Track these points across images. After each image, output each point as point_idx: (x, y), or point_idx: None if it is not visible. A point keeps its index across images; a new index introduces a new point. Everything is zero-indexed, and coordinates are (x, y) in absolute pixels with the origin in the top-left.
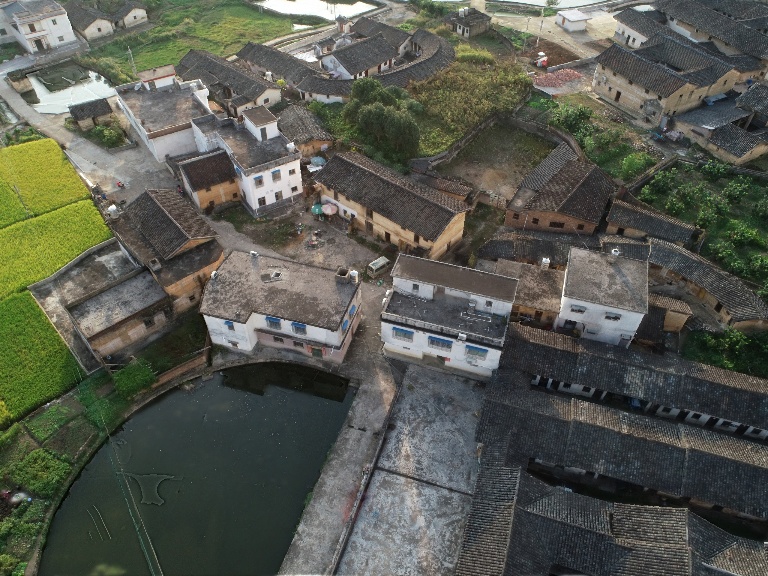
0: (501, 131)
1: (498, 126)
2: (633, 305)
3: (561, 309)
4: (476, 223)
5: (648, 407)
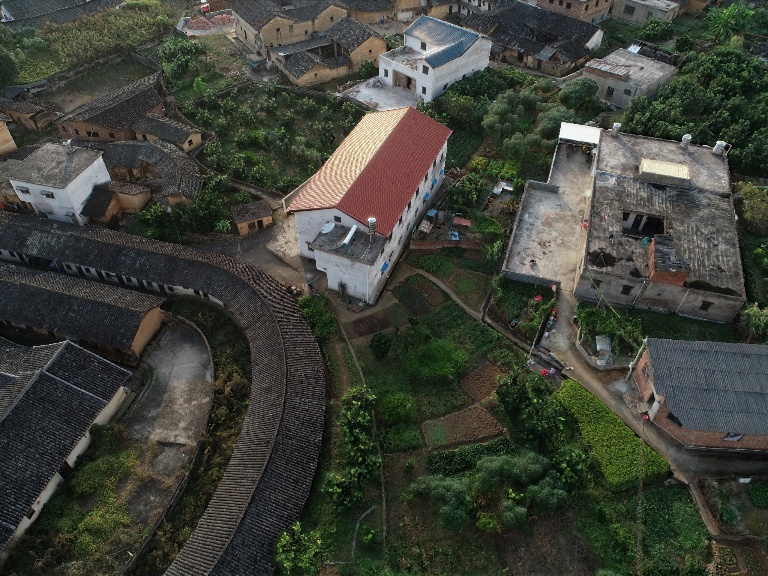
0: (124, 66)
1: (124, 62)
2: (56, 182)
3: (16, 192)
4: (37, 137)
5: (57, 266)
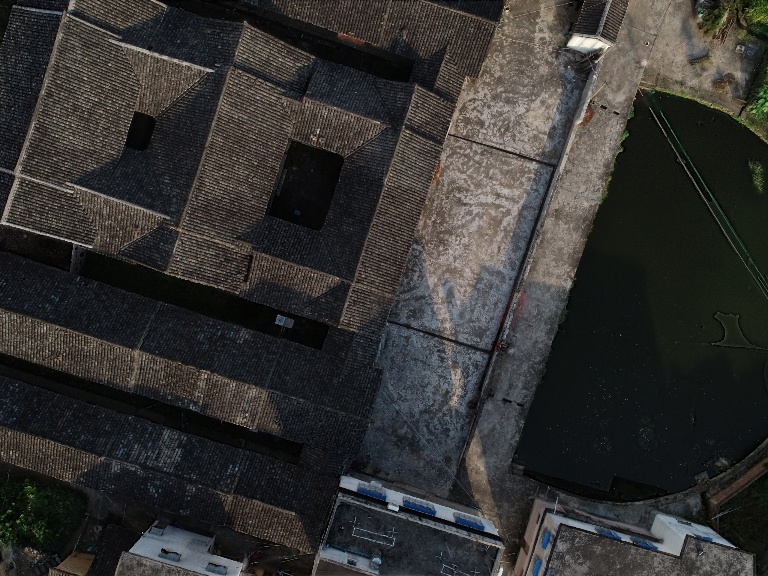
0: None
1: None
2: (139, 568)
3: None
4: None
5: None
